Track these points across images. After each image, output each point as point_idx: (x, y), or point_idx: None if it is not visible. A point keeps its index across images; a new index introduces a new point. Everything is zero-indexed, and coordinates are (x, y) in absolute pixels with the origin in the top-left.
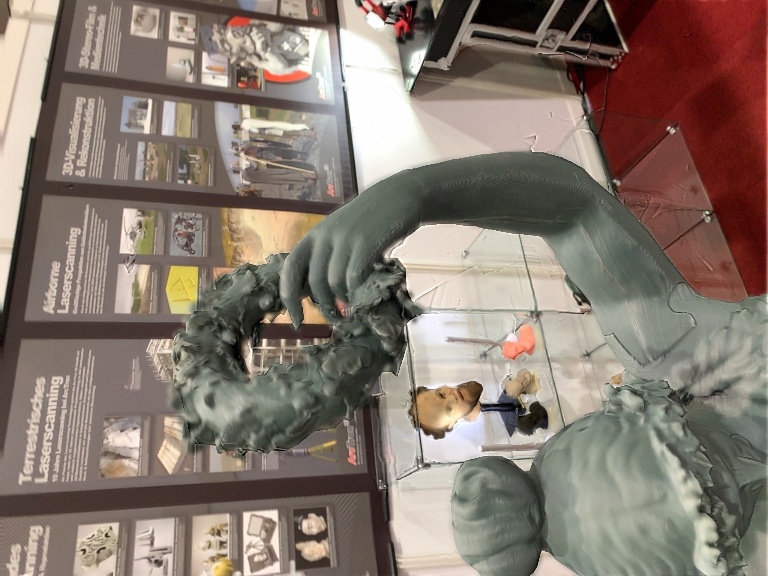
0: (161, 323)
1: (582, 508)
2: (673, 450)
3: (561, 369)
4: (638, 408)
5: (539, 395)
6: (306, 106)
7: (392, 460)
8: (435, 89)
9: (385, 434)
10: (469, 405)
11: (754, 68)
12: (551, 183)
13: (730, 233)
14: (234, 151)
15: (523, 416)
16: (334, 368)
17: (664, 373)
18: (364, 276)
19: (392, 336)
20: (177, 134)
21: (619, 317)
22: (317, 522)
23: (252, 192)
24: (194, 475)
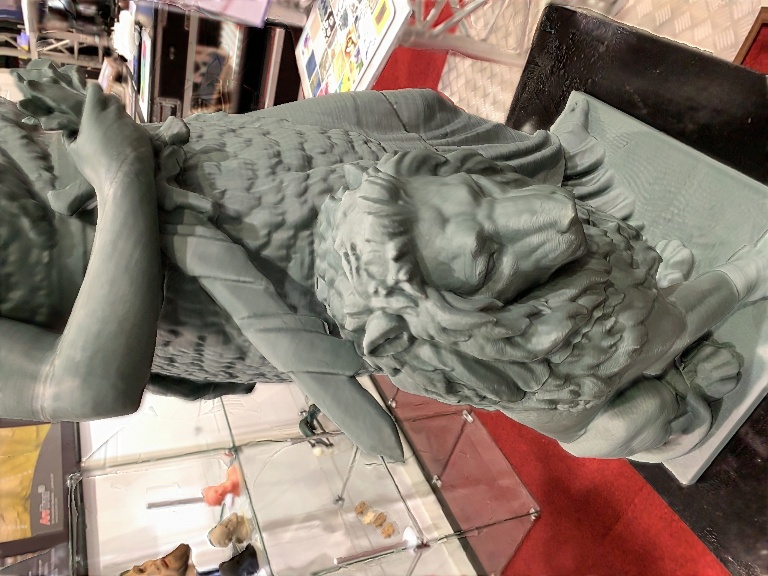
0: None
1: None
2: None
3: (321, 525)
4: None
5: (299, 559)
6: None
7: None
8: None
9: None
10: (176, 573)
11: None
12: None
13: None
14: None
15: None
16: None
17: None
18: None
19: None
20: None
21: None
22: None
23: None
24: None
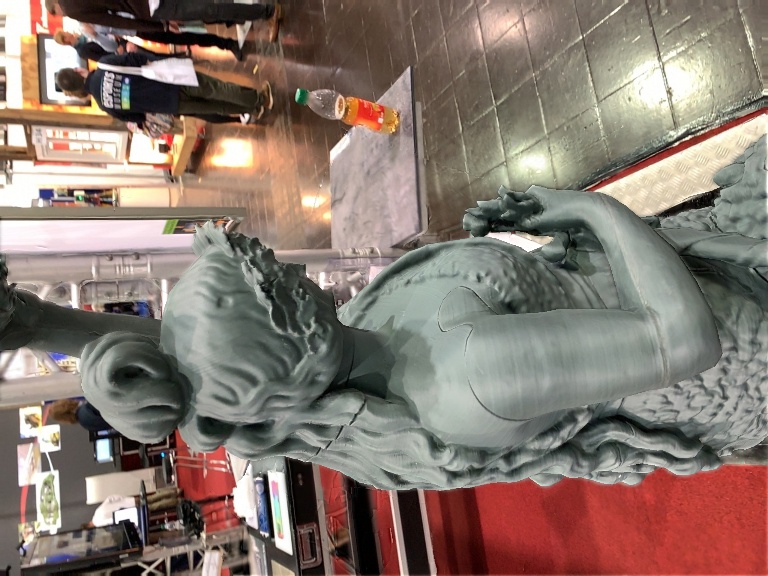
0: None
1: None
2: None
3: None
4: None
5: None
6: None
7: None
8: None
9: None
10: None
11: (575, 543)
12: None
13: None
14: None
15: None
16: None
17: None
18: None
19: None
20: None
21: None
22: None
23: None
24: None
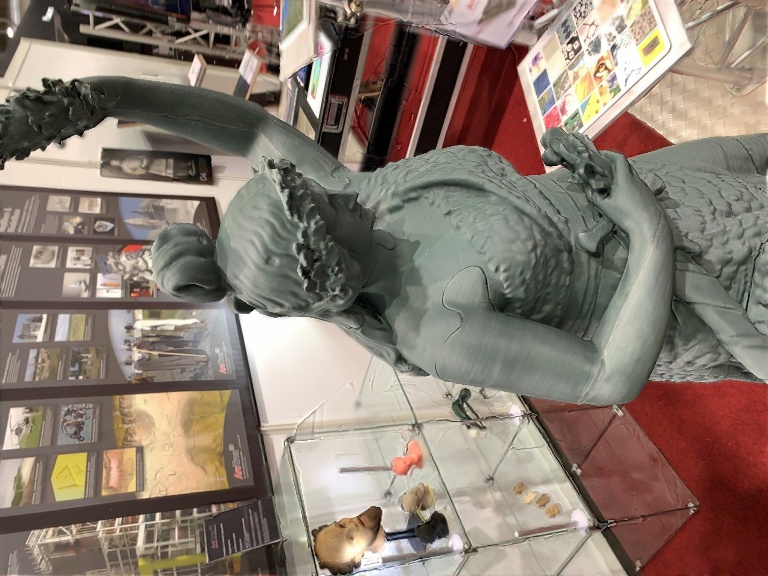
0: (44, 513)
1: (227, 220)
2: None
3: (471, 501)
4: (264, 169)
5: None
6: (196, 305)
7: None
8: None
9: None
10: (371, 531)
11: None
12: (228, 101)
13: None
14: (126, 347)
15: (422, 525)
16: None
17: None
18: None
19: None
20: (70, 339)
21: None
22: None
23: (144, 379)
24: None
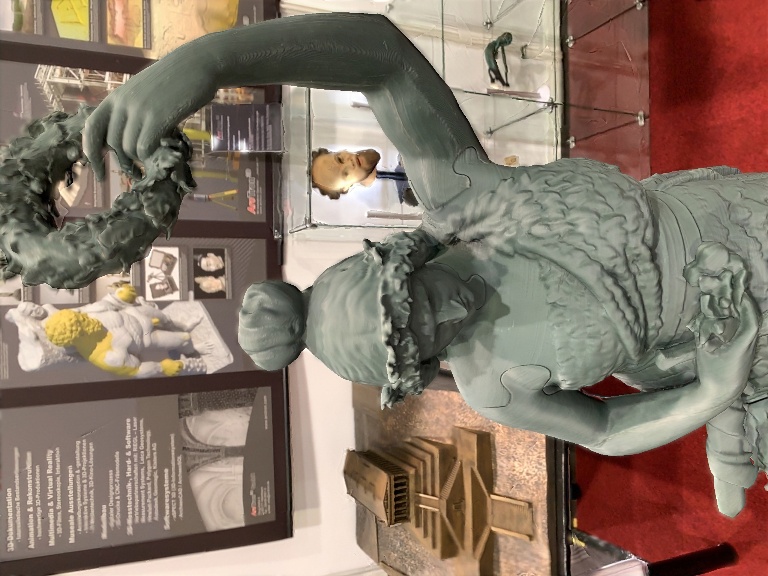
0: (49, 47)
1: (325, 328)
2: (387, 300)
3: None
4: (379, 263)
5: None
6: None
7: (290, 213)
8: None
9: (285, 188)
10: (365, 172)
11: None
12: (357, 53)
13: (654, 26)
14: None
15: None
16: (108, 239)
17: (443, 219)
18: (151, 150)
19: (157, 217)
20: None
21: (415, 170)
22: (215, 261)
23: None
24: (95, 209)
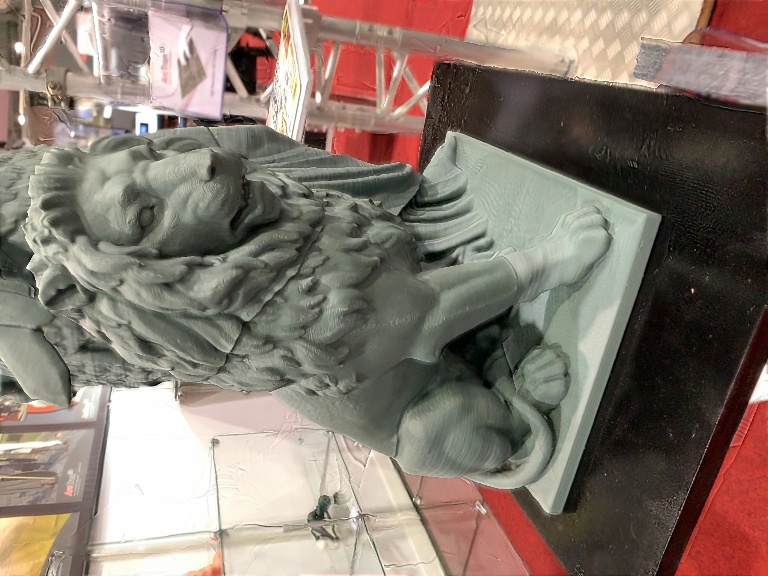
0: None
1: None
2: None
3: None
4: None
5: None
6: (64, 426)
7: None
8: (208, 396)
9: None
10: None
11: None
12: None
13: None
14: None
15: None
16: None
17: None
18: None
19: None
20: None
21: None
22: None
23: None
24: None
